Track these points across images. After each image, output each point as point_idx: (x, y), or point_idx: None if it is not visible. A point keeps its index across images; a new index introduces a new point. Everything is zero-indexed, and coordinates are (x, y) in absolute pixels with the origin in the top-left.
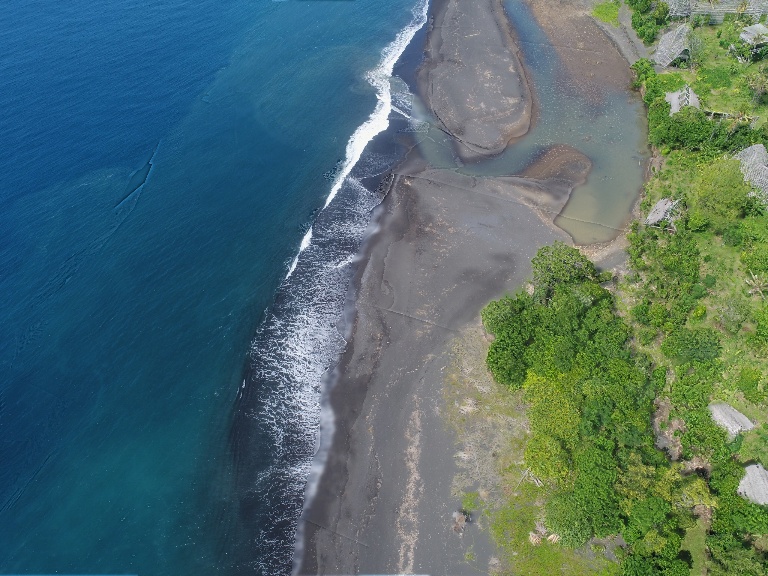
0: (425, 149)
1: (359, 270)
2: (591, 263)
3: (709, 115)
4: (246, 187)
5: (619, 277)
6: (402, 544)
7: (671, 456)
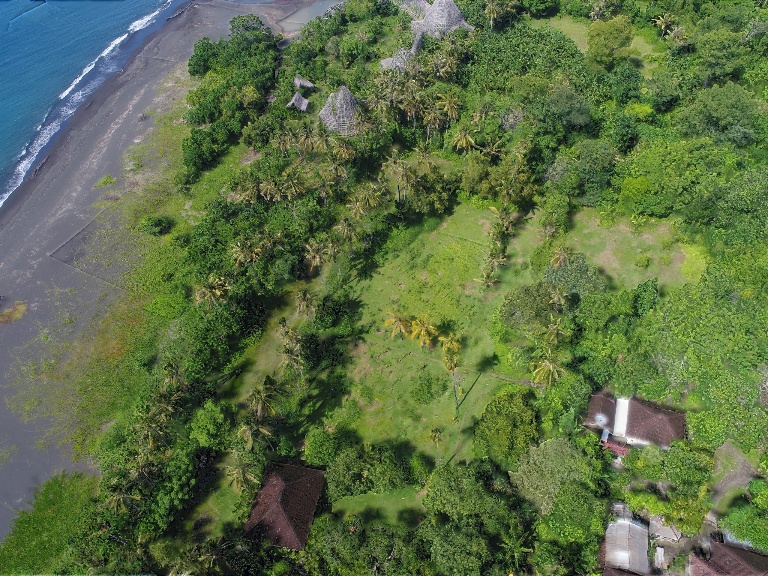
0: None
1: (145, 43)
2: (269, 28)
3: None
4: (87, 2)
5: (295, 42)
6: (111, 129)
7: (272, 104)
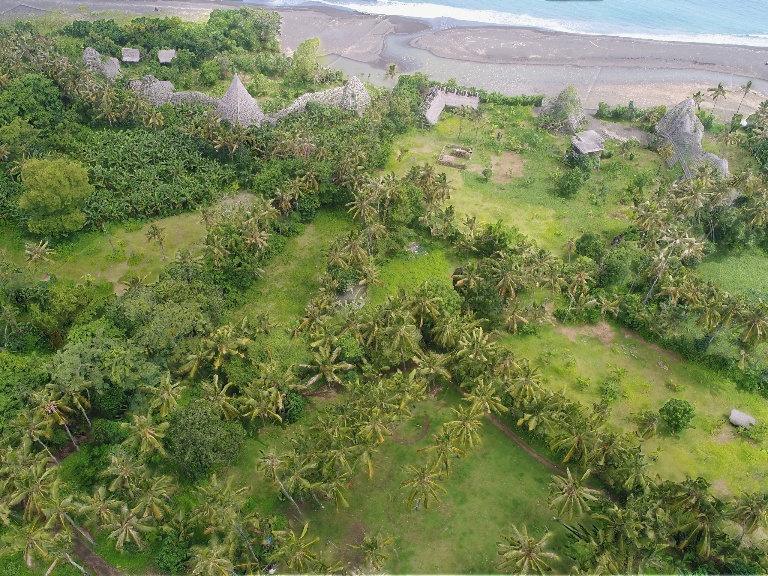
0: (417, 25)
1: (307, 7)
2: None
3: None
4: None
5: None
6: None
7: None
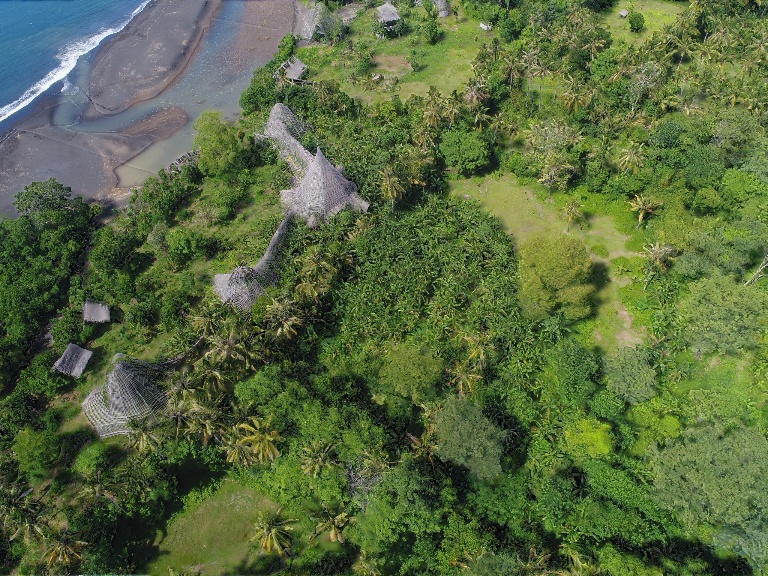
0: (57, 109)
1: None
2: (80, 197)
3: (291, 81)
4: None
5: (123, 212)
6: None
7: (49, 344)
